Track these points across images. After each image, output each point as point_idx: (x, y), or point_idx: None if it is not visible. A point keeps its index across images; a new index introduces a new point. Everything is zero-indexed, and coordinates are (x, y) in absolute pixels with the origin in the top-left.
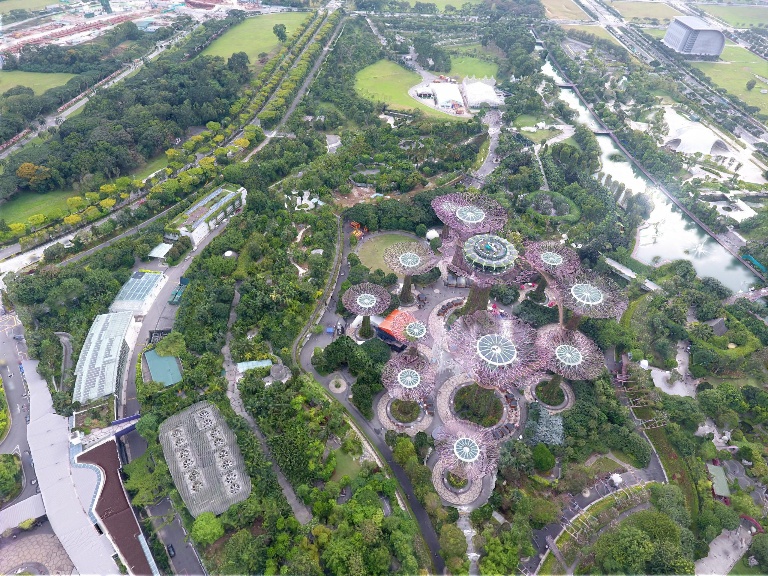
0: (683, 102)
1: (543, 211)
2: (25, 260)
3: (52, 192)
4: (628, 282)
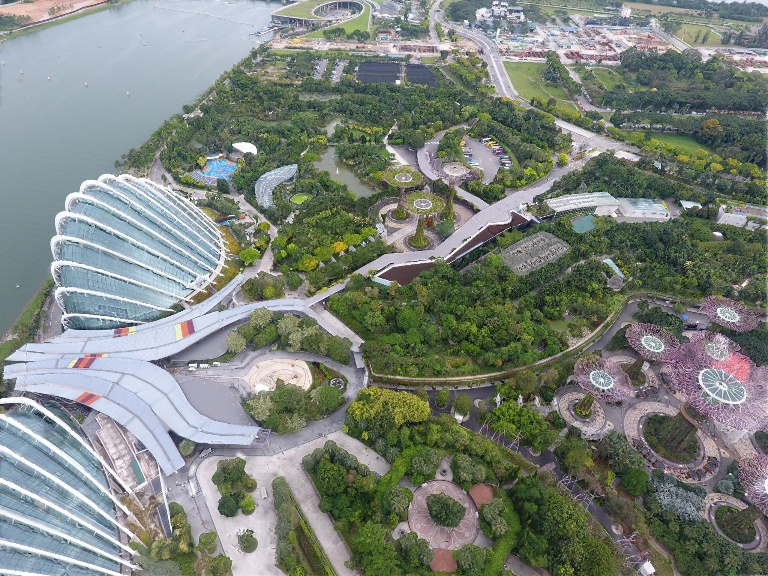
0: None
1: None
2: (631, 157)
3: (705, 146)
4: None
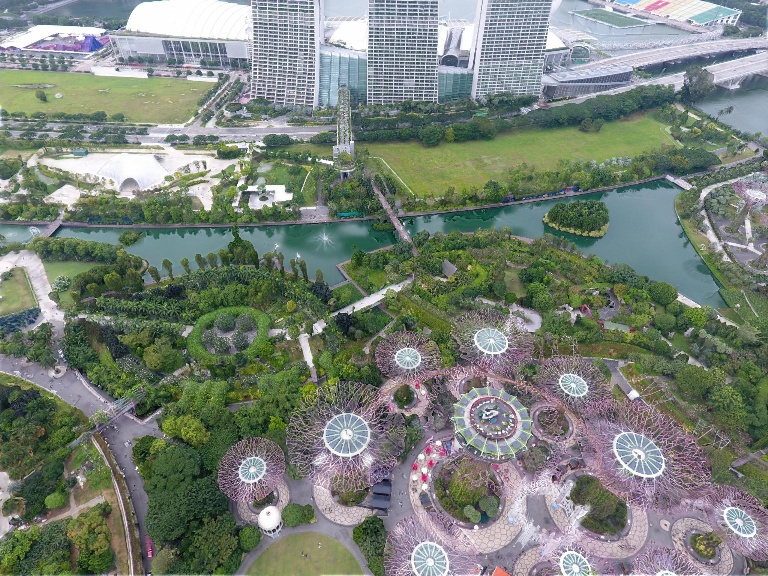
0: (36, 146)
1: (244, 344)
2: None
3: None
4: (377, 306)
